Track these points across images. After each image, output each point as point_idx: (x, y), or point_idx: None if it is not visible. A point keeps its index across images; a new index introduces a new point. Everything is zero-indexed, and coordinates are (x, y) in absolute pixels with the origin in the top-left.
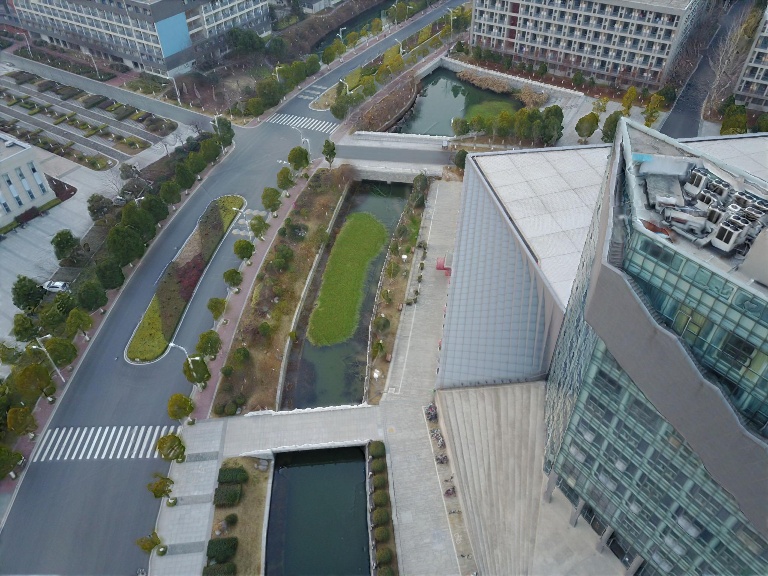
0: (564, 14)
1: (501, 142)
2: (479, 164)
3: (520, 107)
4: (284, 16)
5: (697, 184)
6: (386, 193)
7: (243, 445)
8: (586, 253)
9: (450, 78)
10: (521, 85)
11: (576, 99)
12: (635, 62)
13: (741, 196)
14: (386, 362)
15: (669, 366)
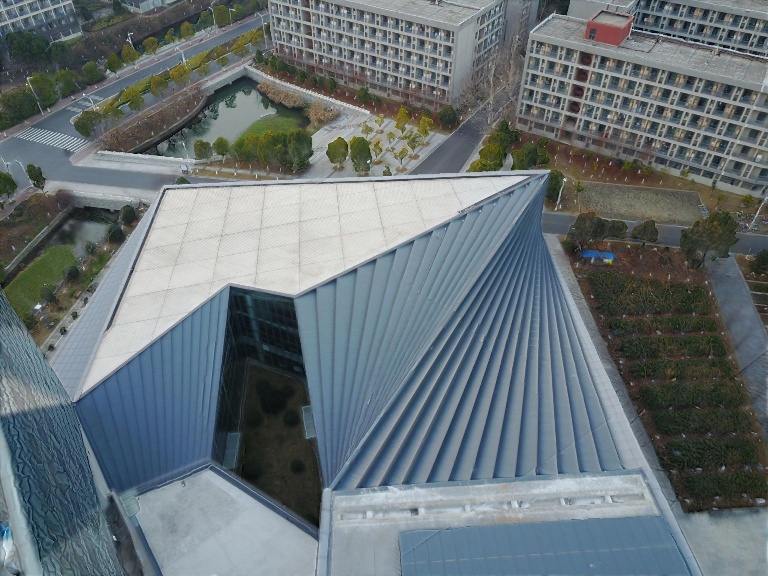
0: (352, 25)
1: (249, 167)
2: (163, 199)
3: (305, 125)
4: (106, 16)
5: None
6: (113, 221)
7: None
8: None
9: (256, 89)
10: (314, 100)
11: (361, 118)
12: (423, 79)
13: None
14: None
15: None
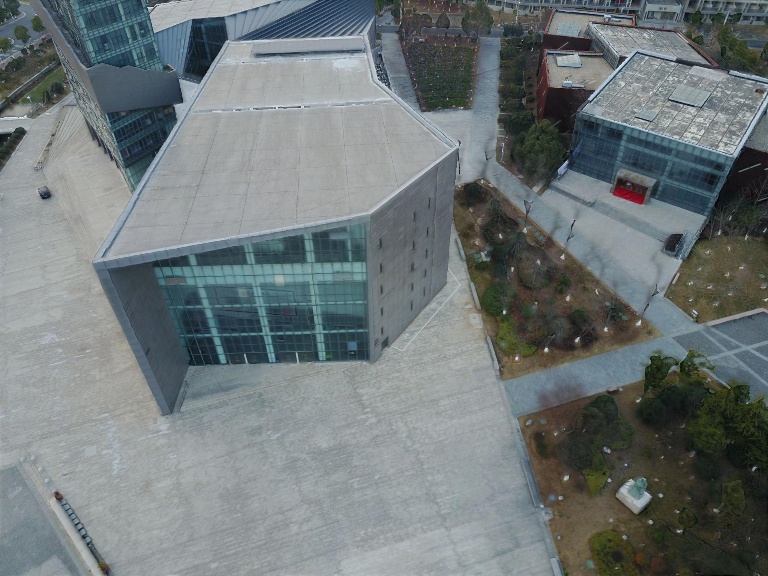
0: None
1: None
2: (156, 7)
3: None
4: None
5: None
6: None
7: None
8: None
9: None
10: None
11: None
12: None
13: None
14: (52, 104)
15: None
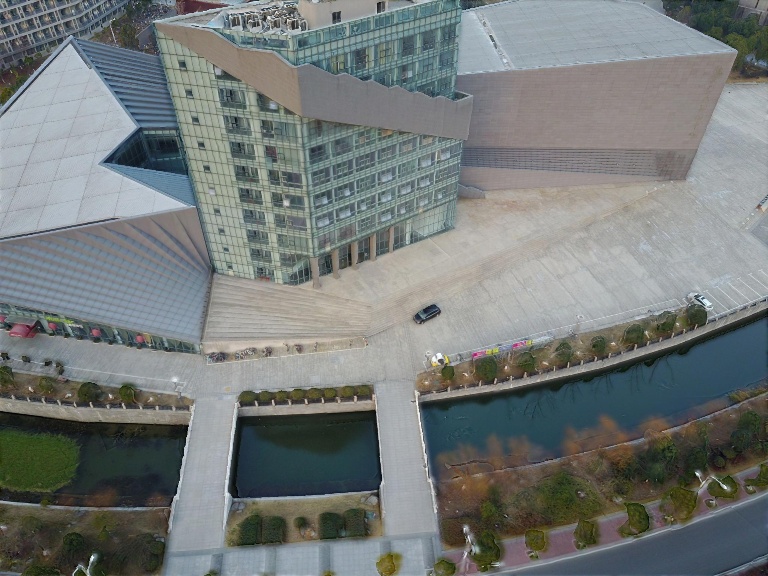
0: None
1: None
2: None
3: None
4: None
5: (239, 24)
6: None
7: (211, 527)
8: (197, 135)
9: None
10: None
11: None
12: None
13: (265, 11)
14: (140, 393)
15: (351, 92)
